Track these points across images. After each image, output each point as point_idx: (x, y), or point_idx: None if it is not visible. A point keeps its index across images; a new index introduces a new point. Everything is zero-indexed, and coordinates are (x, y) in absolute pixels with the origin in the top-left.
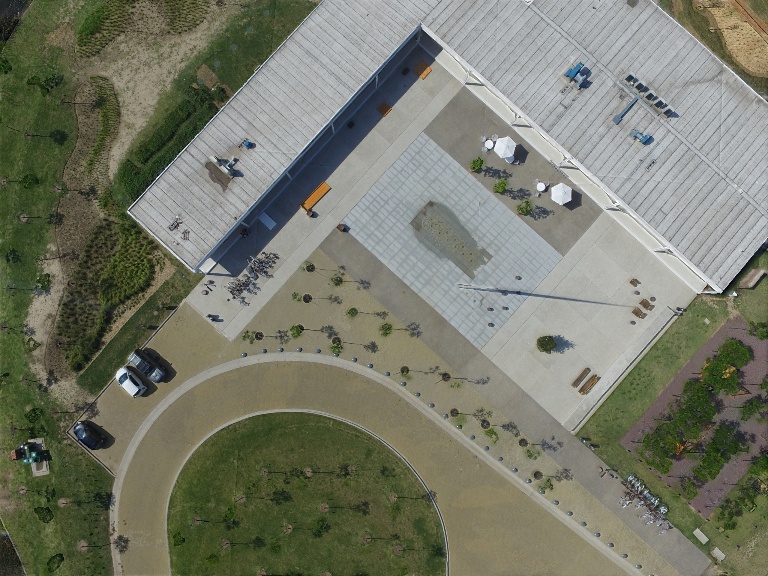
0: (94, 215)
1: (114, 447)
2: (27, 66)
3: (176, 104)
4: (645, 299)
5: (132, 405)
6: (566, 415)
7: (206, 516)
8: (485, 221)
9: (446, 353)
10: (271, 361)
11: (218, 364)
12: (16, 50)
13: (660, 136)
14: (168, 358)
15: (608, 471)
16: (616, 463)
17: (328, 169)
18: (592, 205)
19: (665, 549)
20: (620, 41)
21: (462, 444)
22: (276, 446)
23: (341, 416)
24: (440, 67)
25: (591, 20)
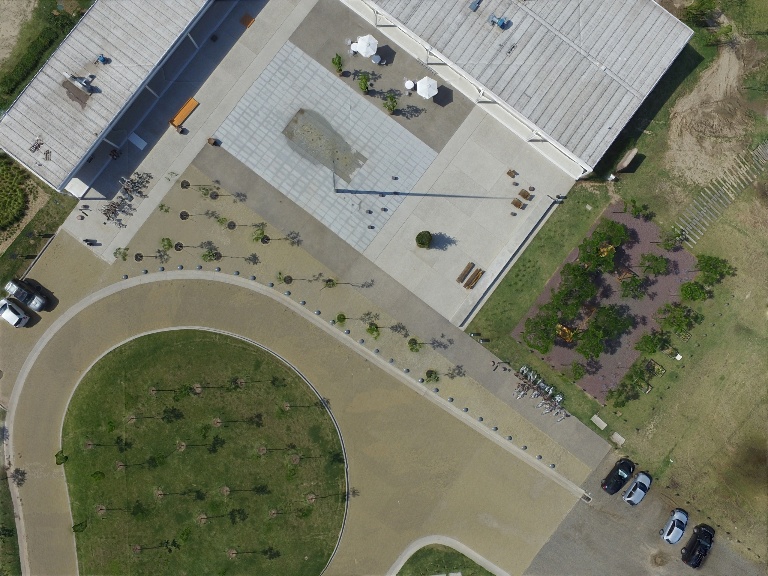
0: None
1: (3, 381)
2: None
3: (38, 32)
4: (524, 189)
5: (17, 337)
6: (453, 311)
7: (97, 440)
8: (357, 124)
9: (328, 259)
10: (153, 281)
11: (100, 289)
12: None
13: (519, 20)
14: (49, 287)
15: (499, 364)
16: (508, 356)
17: (195, 85)
18: (464, 100)
19: (564, 438)
20: None
21: (351, 349)
22: (162, 364)
23: (227, 330)
24: None
25: None
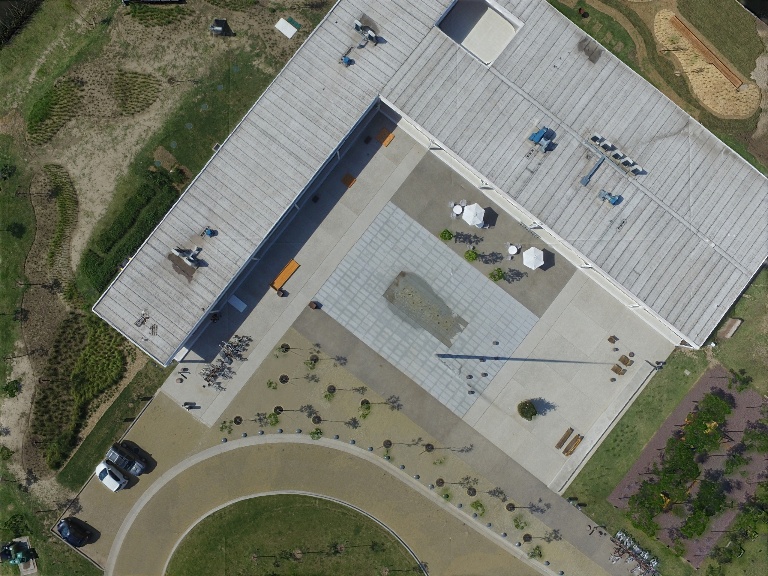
0: (60, 309)
1: (100, 541)
2: None
3: (135, 189)
4: (624, 355)
5: (115, 498)
6: (551, 477)
7: None
8: (458, 288)
9: (428, 424)
10: (252, 445)
11: (198, 451)
12: None
13: (629, 195)
14: (147, 449)
15: (596, 529)
16: (604, 520)
17: (296, 246)
18: (565, 264)
19: None
20: (583, 99)
21: (449, 513)
22: (263, 530)
23: (326, 494)
24: (403, 133)
25: (553, 79)
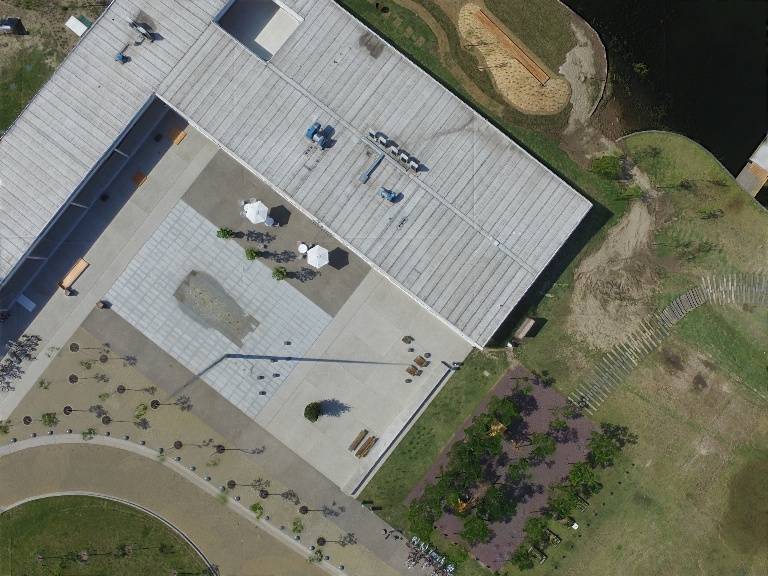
0: None
1: None
2: None
3: None
4: (419, 356)
5: None
6: (345, 479)
7: None
8: (250, 287)
9: (219, 425)
10: (41, 445)
11: None
12: None
13: (410, 192)
14: None
15: (391, 533)
16: (400, 524)
17: (85, 245)
18: (360, 263)
19: None
20: (364, 95)
21: (241, 515)
22: (49, 531)
23: (116, 496)
24: (195, 130)
25: (333, 75)
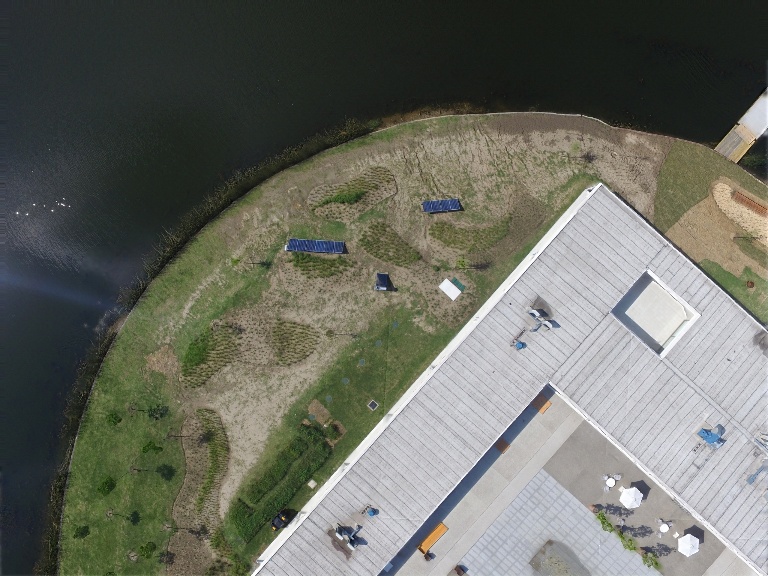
0: (206, 555)
1: None
2: (128, 390)
3: (287, 441)
4: None
5: None
6: None
7: None
8: (605, 559)
9: None
10: None
11: None
12: (115, 369)
13: None
14: None
15: None
16: None
17: (445, 509)
18: (714, 541)
19: None
20: (755, 395)
21: None
22: None
23: None
24: (560, 400)
25: (726, 373)
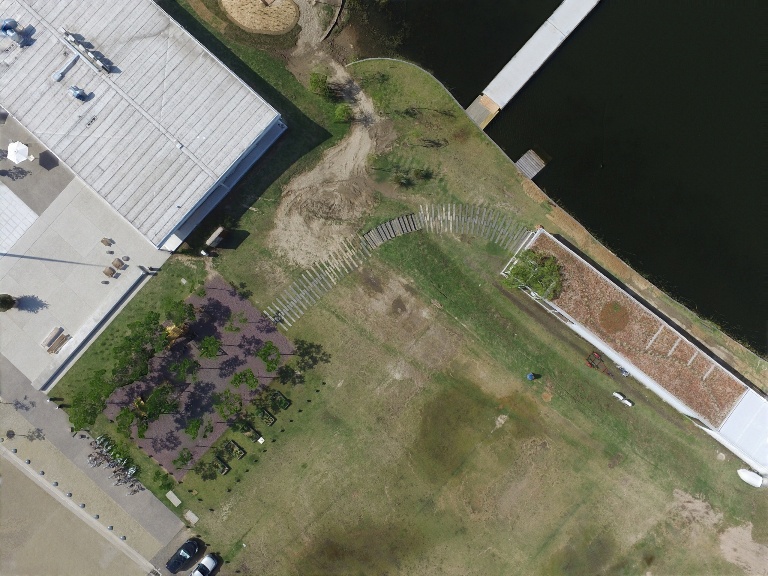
0: None
1: None
2: None
3: None
4: (118, 259)
5: None
6: (37, 374)
7: None
8: None
9: None
10: None
11: None
12: None
13: (101, 92)
14: None
15: (76, 431)
16: None
17: None
18: None
19: (137, 511)
20: None
21: None
22: None
23: None
24: None
25: None
